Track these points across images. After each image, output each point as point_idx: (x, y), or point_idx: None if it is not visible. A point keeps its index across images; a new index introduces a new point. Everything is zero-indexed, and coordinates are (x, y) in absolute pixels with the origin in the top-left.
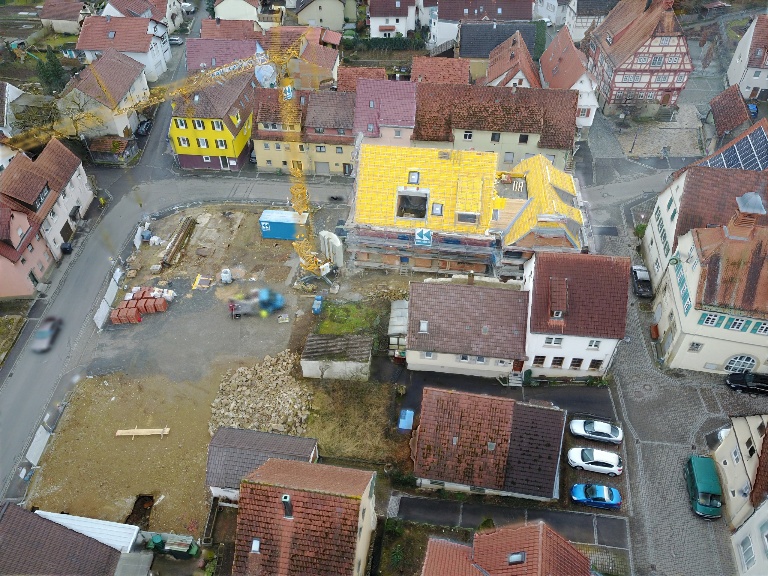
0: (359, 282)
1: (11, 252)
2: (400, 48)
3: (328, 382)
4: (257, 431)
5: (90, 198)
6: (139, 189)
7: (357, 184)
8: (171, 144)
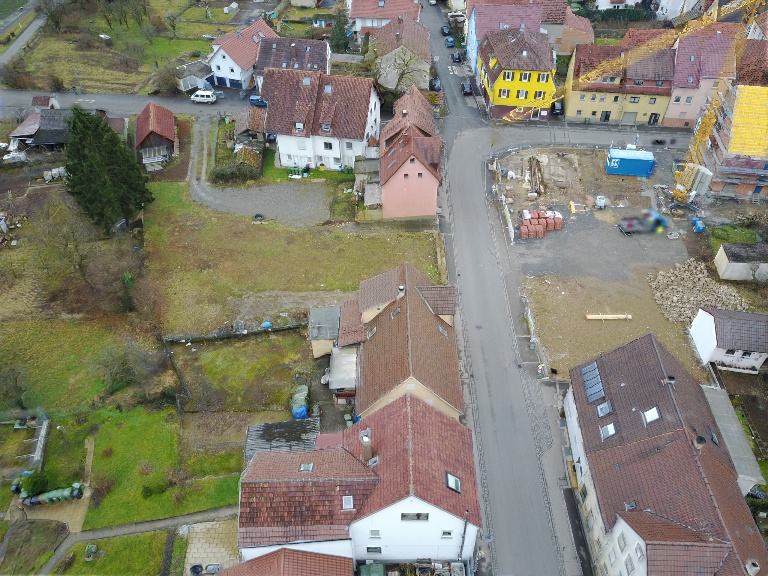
0: (718, 209)
1: (437, 175)
2: (632, 19)
3: (746, 283)
4: (736, 311)
5: None
6: (464, 135)
7: (733, 120)
8: (491, 96)
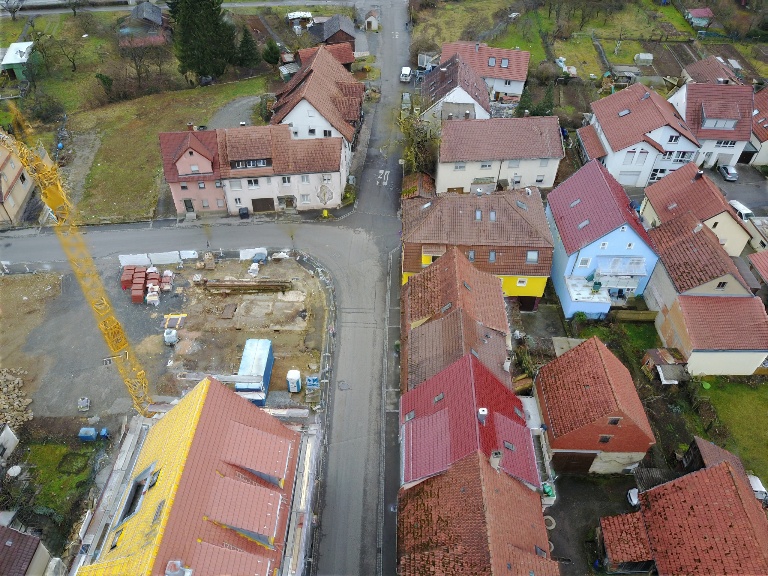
0: None
1: (173, 174)
2: None
3: None
4: None
5: (330, 204)
6: (357, 234)
7: (176, 405)
8: None
